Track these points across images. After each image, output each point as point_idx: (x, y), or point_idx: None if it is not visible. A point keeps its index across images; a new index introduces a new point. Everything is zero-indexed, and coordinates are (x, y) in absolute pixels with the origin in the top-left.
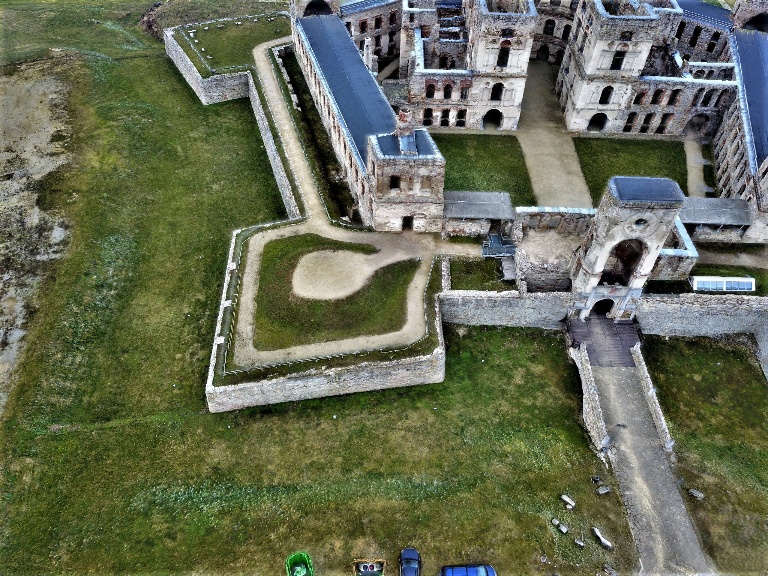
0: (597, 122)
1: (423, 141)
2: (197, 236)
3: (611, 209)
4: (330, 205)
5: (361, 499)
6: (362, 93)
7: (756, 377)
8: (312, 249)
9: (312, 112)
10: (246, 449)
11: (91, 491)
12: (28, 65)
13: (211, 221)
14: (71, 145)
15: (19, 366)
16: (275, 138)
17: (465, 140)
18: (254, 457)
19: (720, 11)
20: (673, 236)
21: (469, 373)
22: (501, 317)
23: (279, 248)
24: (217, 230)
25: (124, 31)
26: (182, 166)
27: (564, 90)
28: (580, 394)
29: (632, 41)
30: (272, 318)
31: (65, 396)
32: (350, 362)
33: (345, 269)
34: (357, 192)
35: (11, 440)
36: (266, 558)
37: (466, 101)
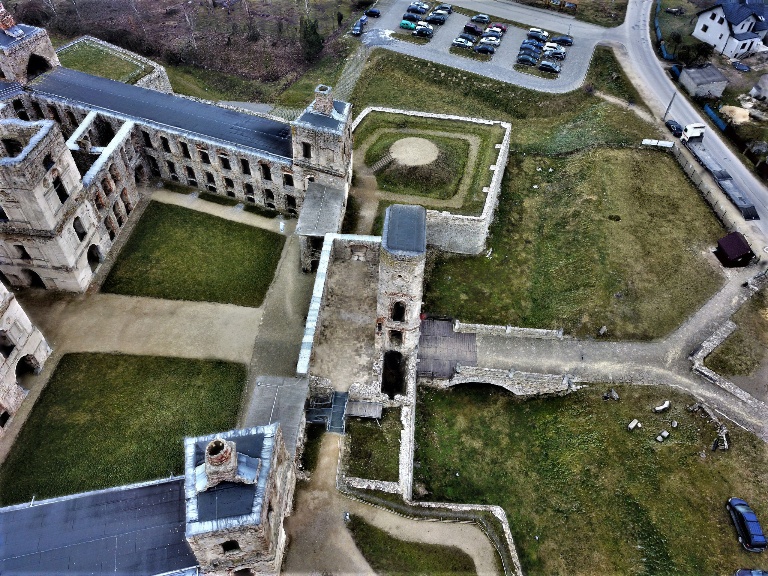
0: None
1: None
2: None
3: (418, 267)
4: None
5: None
6: None
7: (462, 259)
8: None
9: None
10: None
11: None
12: None
13: None
14: None
15: None
16: None
17: (44, 421)
18: None
19: None
20: None
21: (475, 493)
22: None
23: None
24: None
25: None
26: None
27: (11, 270)
28: (490, 391)
29: (55, 162)
30: None
31: None
32: None
33: None
34: None
35: None
36: None
37: None
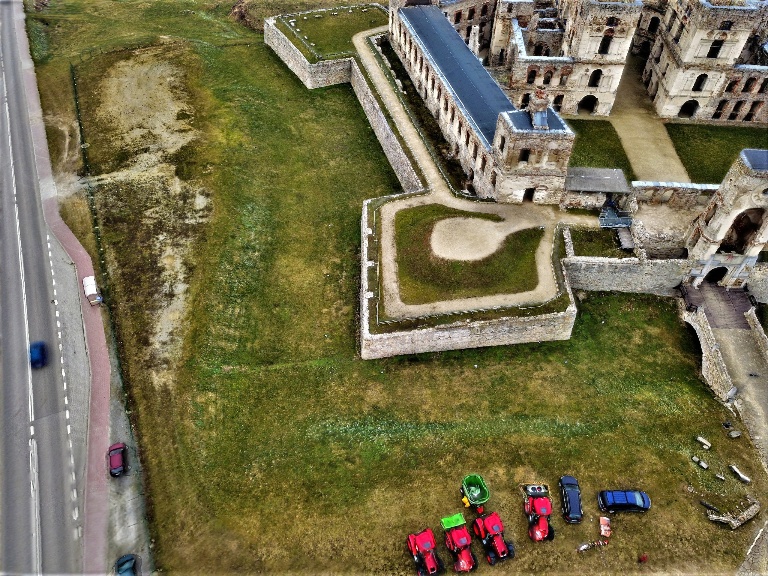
0: (686, 109)
1: (552, 117)
2: (323, 206)
3: (741, 178)
4: (450, 179)
5: (515, 435)
6: (473, 77)
7: None
8: (443, 216)
9: (415, 96)
10: (400, 391)
11: (269, 422)
12: (142, 51)
13: (333, 193)
14: (196, 123)
15: (188, 314)
16: (387, 119)
17: None
18: (409, 398)
19: None
20: None
21: (591, 333)
22: (619, 283)
23: (409, 216)
24: (340, 201)
25: (219, 21)
26: (298, 144)
27: (654, 78)
28: (697, 354)
29: (731, 30)
30: (414, 276)
31: (231, 341)
32: (492, 316)
33: (478, 234)
34: (473, 168)
35: (194, 376)
36: (439, 480)
37: (564, 87)
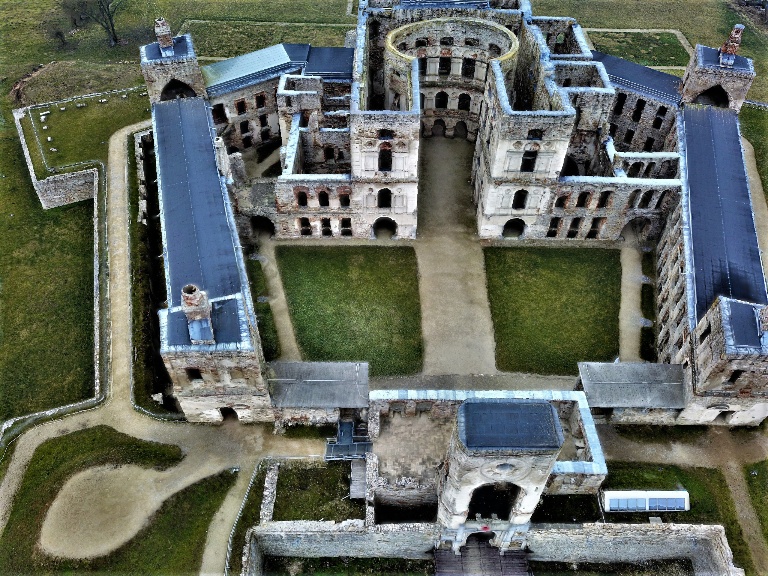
0: (516, 225)
1: (228, 320)
2: None
3: (458, 453)
4: (142, 376)
5: None
6: (201, 215)
7: None
8: (89, 461)
9: None
10: None
11: None
12: None
13: (2, 389)
14: None
15: None
16: (101, 268)
17: (350, 255)
18: None
19: (667, 79)
20: (580, 429)
21: None
22: (346, 549)
23: (54, 453)
24: (6, 403)
25: None
26: None
27: (476, 185)
28: None
29: (543, 140)
30: None
31: None
32: None
33: (122, 500)
34: None
35: None
36: None
37: (348, 209)
